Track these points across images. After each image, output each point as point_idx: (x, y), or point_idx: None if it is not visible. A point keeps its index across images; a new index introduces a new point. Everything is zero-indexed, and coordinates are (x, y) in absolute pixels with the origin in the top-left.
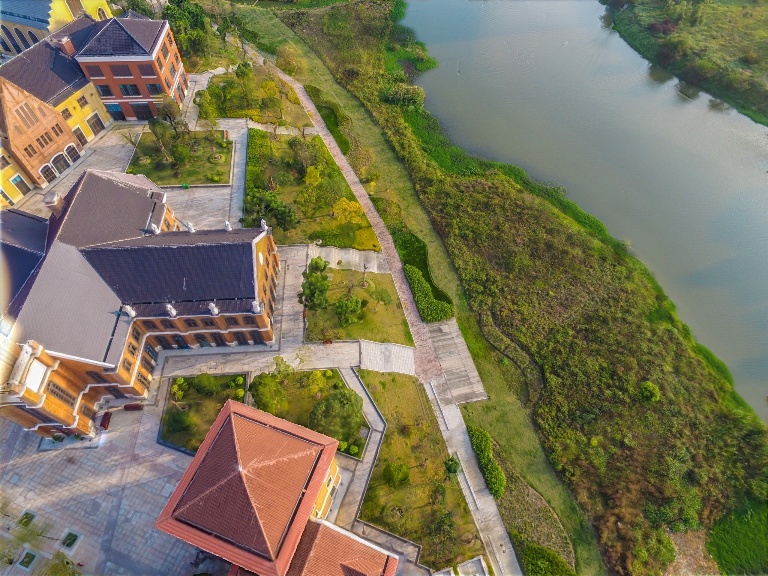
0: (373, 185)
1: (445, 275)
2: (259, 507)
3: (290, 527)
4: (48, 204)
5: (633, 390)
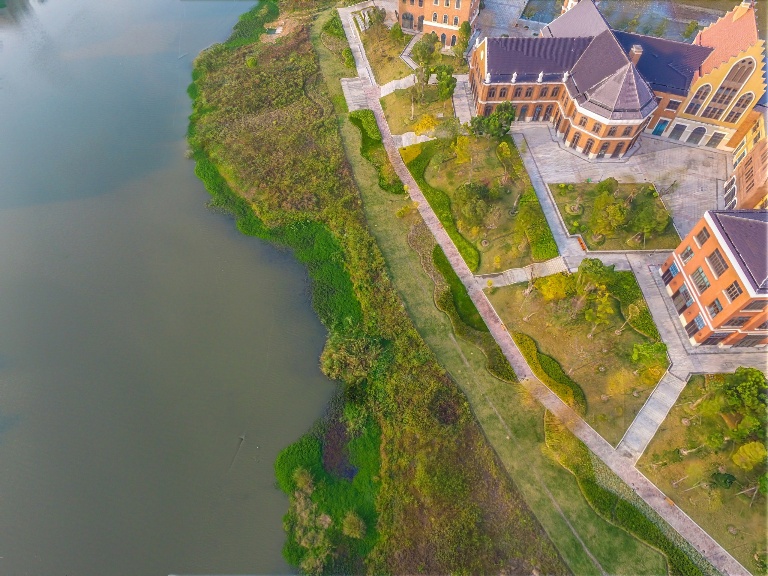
0: None
1: (350, 134)
2: None
3: None
4: None
5: (256, 75)
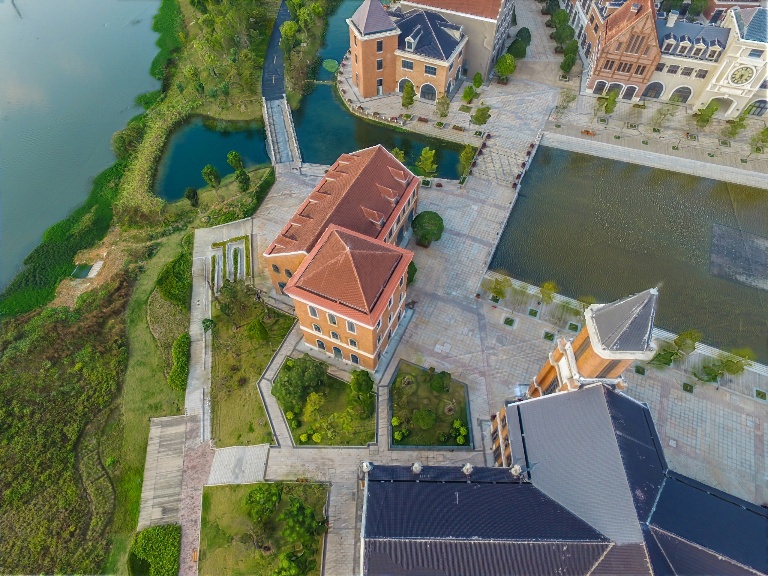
0: None
1: None
2: None
3: None
4: None
5: None
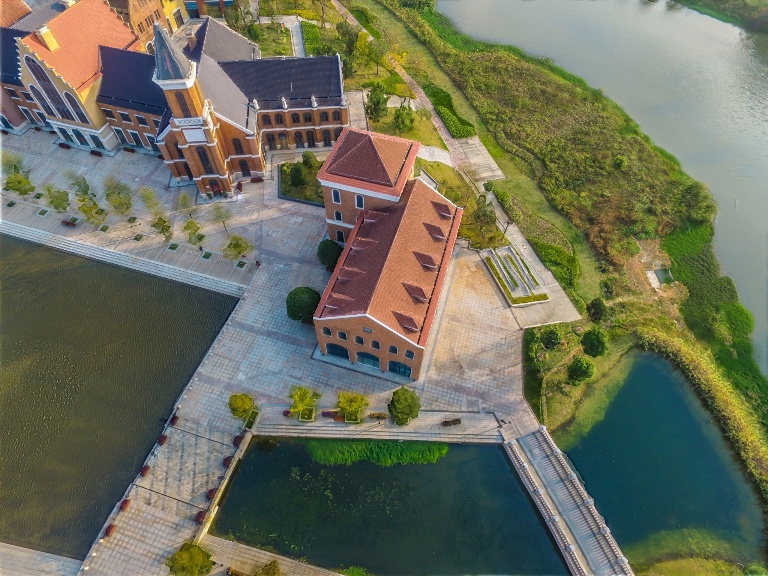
0: (405, 55)
1: (467, 111)
2: (382, 158)
3: (400, 174)
4: (188, 36)
5: (609, 168)
